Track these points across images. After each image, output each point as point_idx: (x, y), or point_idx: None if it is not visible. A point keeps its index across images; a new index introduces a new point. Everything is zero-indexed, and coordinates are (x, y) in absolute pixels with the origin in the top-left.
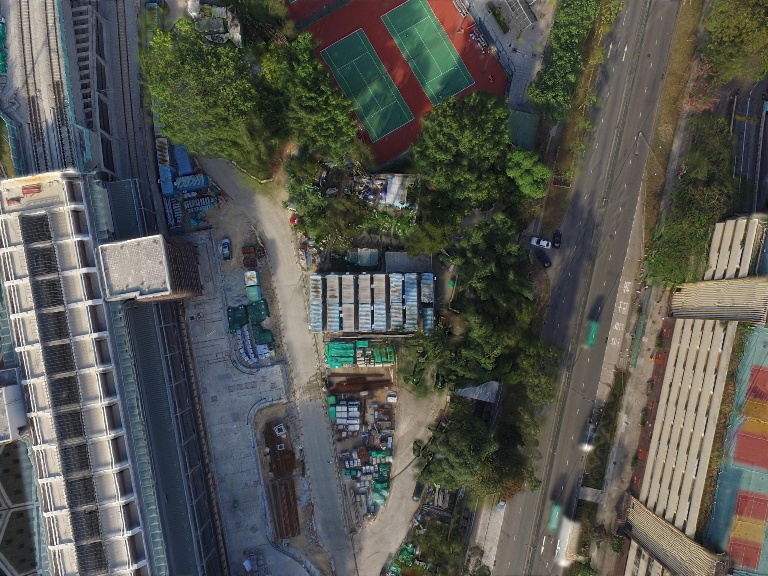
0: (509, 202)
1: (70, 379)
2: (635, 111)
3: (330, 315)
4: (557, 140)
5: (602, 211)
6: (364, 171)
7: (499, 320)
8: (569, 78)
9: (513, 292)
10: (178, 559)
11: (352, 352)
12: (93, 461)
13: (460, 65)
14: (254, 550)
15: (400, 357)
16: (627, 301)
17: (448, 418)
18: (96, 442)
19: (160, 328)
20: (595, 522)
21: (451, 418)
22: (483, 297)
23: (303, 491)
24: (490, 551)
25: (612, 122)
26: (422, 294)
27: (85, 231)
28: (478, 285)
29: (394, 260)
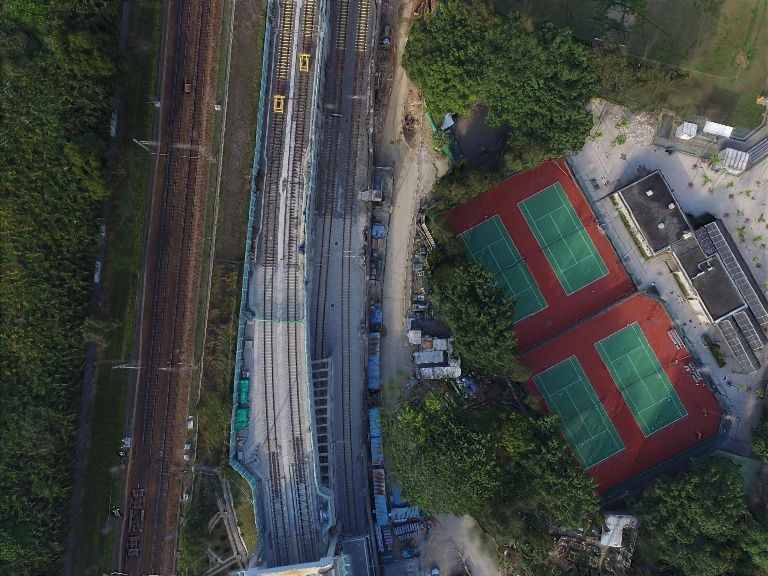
0: (740, 571)
1: None
2: None
3: None
4: None
5: None
6: None
7: None
8: None
9: None
10: None
11: None
12: None
13: (673, 396)
14: None
15: None
16: None
17: None
18: None
19: None
20: None
21: None
22: None
23: None
24: None
25: None
26: None
27: None
28: None
29: None
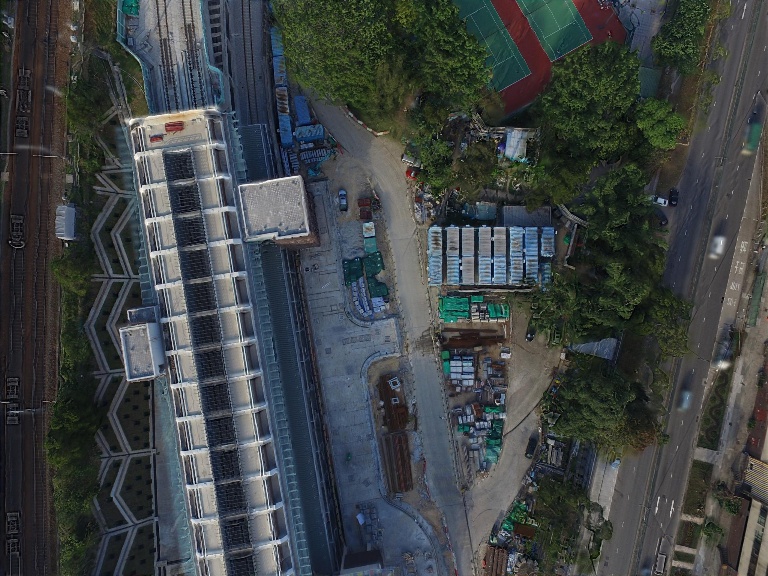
0: (637, 155)
1: (212, 317)
2: (754, 70)
3: (450, 267)
4: (675, 97)
5: (720, 170)
6: (484, 124)
7: (631, 271)
8: (699, 30)
9: (646, 243)
10: (304, 506)
11: (467, 307)
12: (233, 400)
13: (578, 20)
14: (367, 504)
15: (514, 313)
16: (744, 261)
17: (562, 375)
18: (235, 381)
19: (287, 274)
20: (710, 483)
21: (565, 375)
22: (618, 246)
23: (416, 446)
24: (603, 510)
25: (730, 80)
26: (543, 248)
27: (224, 171)
28: (612, 234)
29: (512, 214)
